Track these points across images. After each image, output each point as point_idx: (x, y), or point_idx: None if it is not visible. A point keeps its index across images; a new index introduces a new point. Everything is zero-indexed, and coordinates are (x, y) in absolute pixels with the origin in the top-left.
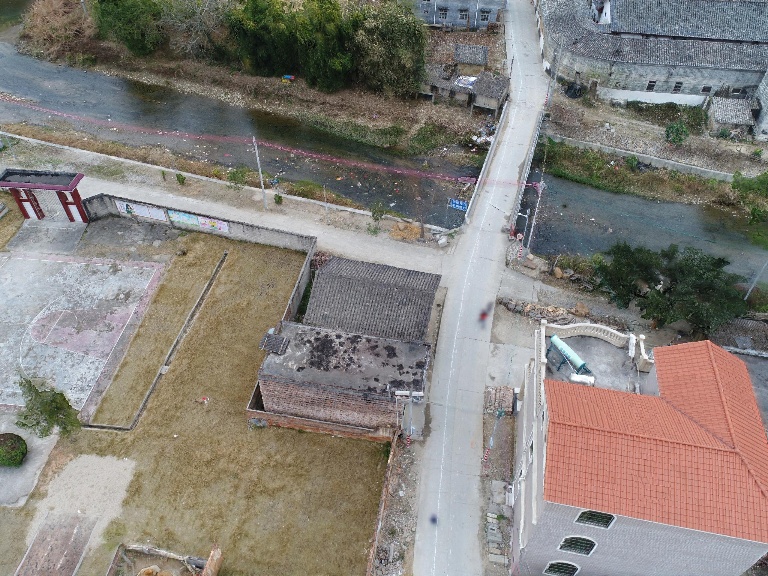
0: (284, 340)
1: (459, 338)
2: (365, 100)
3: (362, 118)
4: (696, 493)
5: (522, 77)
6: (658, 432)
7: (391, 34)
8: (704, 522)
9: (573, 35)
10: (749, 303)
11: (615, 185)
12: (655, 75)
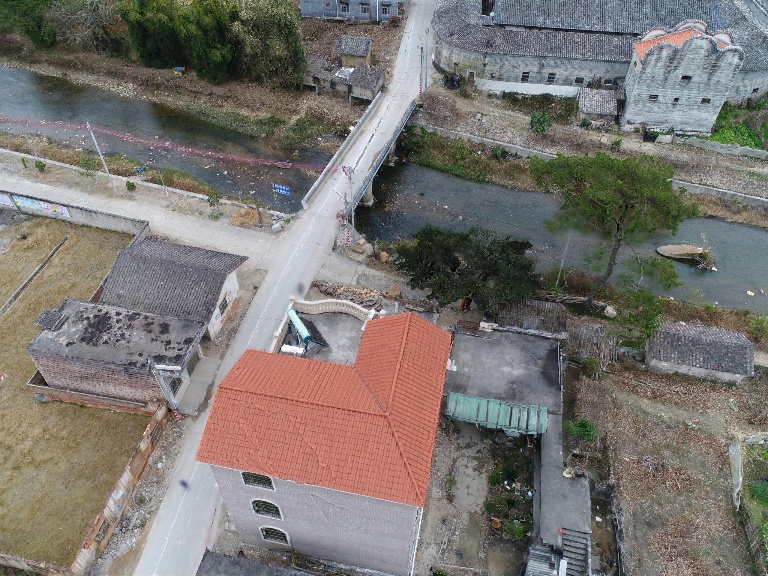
0: (62, 317)
1: (263, 319)
2: (251, 91)
3: (245, 109)
4: (339, 454)
5: (407, 69)
6: (322, 397)
7: (264, 25)
8: (340, 482)
9: (452, 27)
10: (572, 288)
11: (477, 174)
12: (527, 66)
